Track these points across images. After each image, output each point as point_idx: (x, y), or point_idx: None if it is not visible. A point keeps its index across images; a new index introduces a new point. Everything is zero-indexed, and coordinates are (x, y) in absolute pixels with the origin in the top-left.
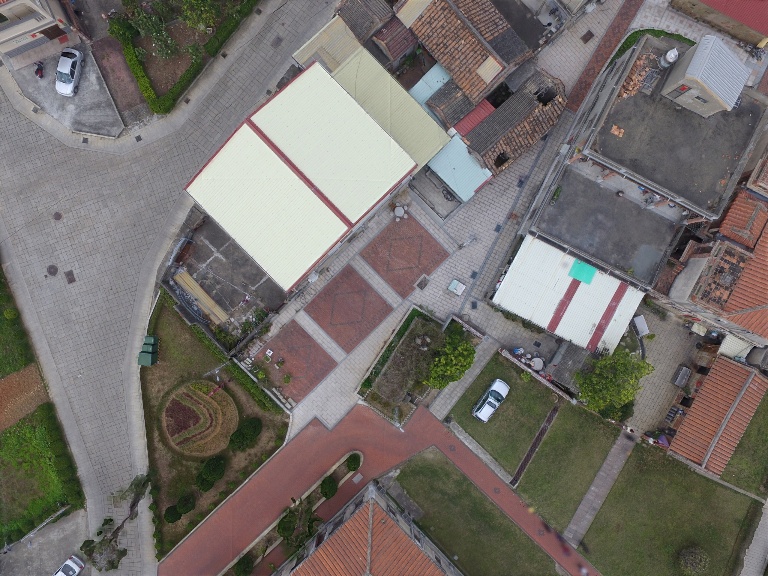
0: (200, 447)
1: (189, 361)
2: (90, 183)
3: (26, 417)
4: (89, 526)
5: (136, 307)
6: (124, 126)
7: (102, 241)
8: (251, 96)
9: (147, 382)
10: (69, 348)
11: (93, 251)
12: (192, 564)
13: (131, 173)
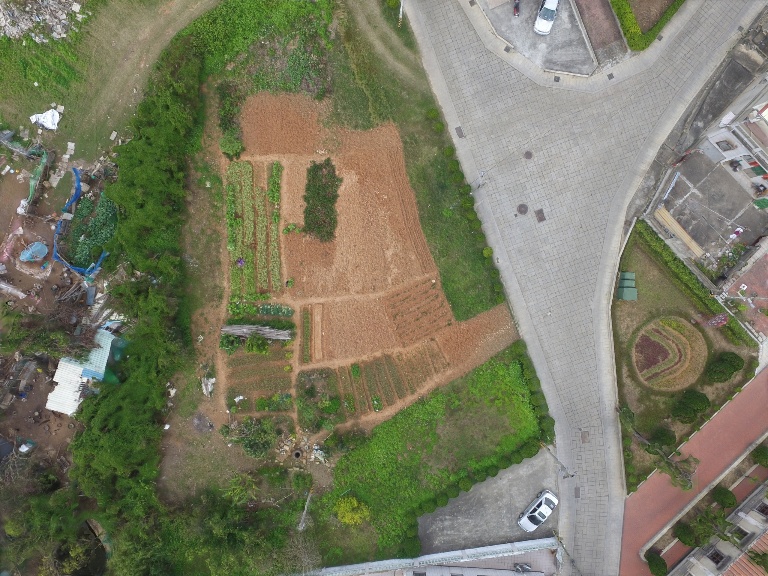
0: (669, 382)
1: (657, 297)
2: (561, 122)
3: (497, 355)
4: None
5: (606, 245)
6: (598, 64)
7: (572, 179)
8: (723, 33)
9: (616, 319)
10: (539, 286)
11: (563, 190)
12: (659, 497)
13: (603, 111)
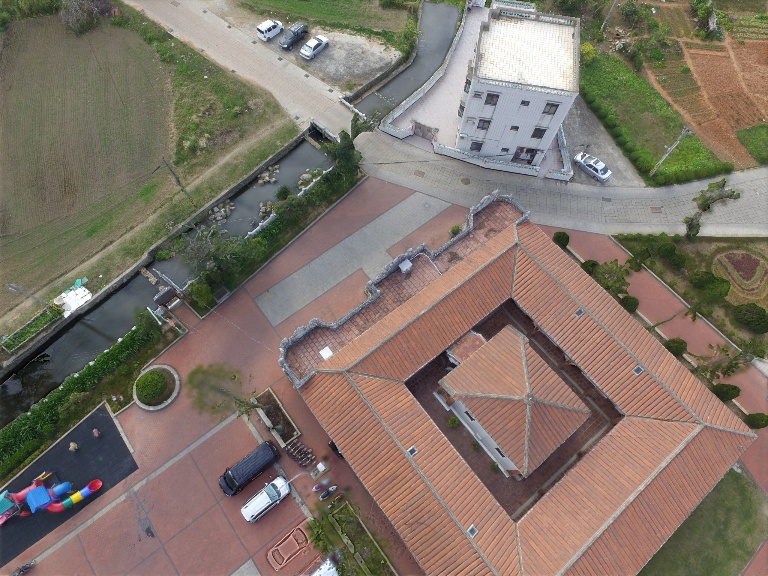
0: None
1: None
2: None
3: (715, 155)
4: (632, 188)
5: None
6: None
7: None
8: None
9: (767, 242)
10: None
11: None
12: (610, 261)
13: None
